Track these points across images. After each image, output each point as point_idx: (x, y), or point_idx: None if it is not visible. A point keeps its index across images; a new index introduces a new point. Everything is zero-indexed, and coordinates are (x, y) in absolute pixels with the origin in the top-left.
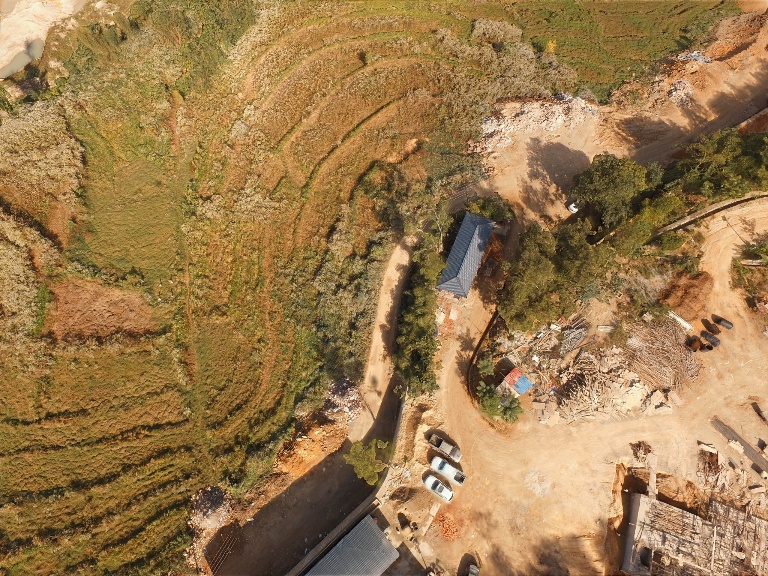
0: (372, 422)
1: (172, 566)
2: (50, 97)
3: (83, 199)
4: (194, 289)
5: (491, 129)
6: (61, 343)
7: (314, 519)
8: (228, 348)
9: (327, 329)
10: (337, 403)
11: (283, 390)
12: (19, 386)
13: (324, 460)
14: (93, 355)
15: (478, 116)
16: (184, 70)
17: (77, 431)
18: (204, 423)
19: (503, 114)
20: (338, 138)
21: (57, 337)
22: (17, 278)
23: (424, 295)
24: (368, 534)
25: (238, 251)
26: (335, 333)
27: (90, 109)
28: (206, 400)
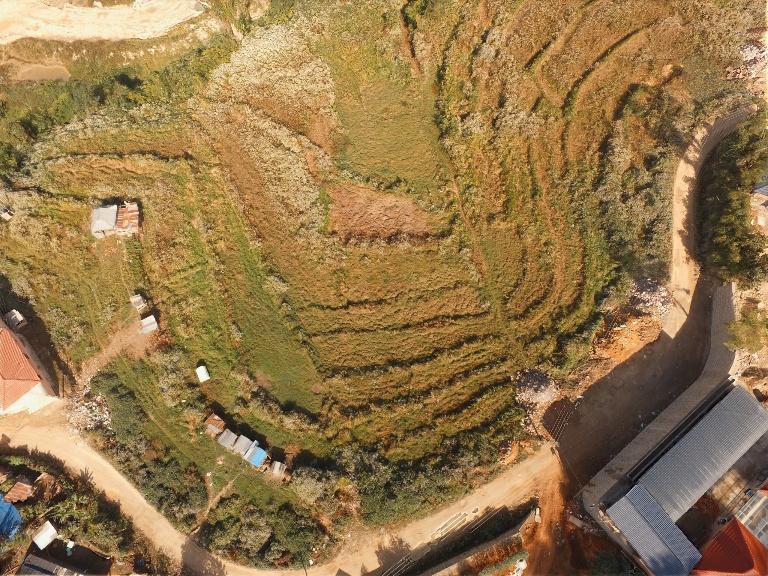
0: (685, 317)
1: (514, 432)
2: (282, 22)
3: (337, 114)
4: (469, 197)
5: (751, 56)
6: (352, 240)
7: (644, 399)
8: (513, 251)
9: (622, 233)
10: (646, 299)
11: (583, 288)
12: (317, 276)
13: (643, 348)
14: (383, 252)
15: (735, 44)
16: (403, 1)
17: (382, 317)
18: (505, 315)
19: (761, 42)
20: (588, 63)
21: (340, 236)
22: (300, 180)
23: (742, 198)
24: (743, 401)
25: (509, 163)
26: (630, 237)
27: (327, 33)
28: (501, 296)
